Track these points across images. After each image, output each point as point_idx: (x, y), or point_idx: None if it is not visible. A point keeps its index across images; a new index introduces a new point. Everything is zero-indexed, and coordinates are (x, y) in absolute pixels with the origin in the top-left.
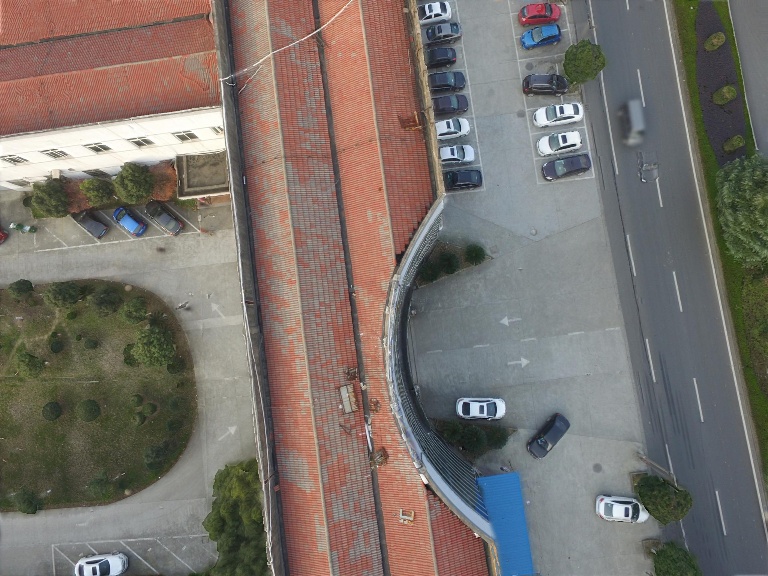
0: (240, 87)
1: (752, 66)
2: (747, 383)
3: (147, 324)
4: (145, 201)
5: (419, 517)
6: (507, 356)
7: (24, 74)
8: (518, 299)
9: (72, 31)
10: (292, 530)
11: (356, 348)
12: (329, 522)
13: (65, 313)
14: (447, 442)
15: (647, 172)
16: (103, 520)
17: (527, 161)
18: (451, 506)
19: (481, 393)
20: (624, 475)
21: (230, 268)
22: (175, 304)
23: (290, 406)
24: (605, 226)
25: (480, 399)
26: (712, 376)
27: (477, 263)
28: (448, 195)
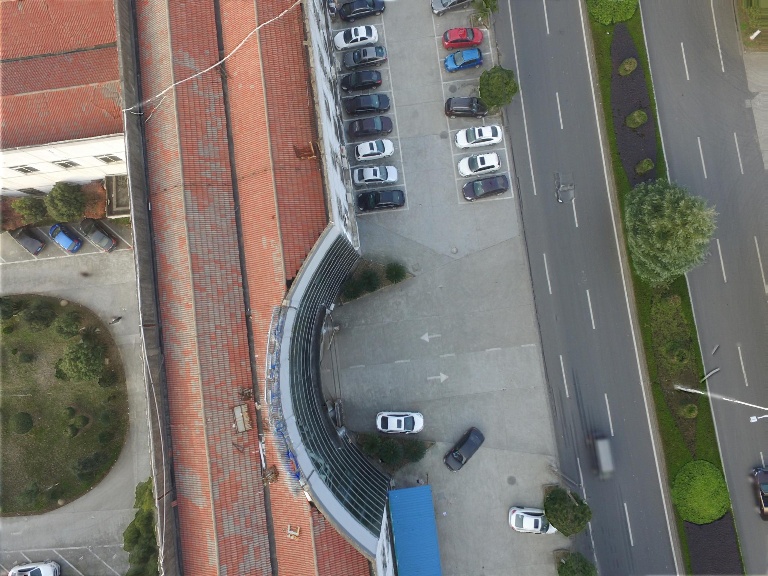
0: (146, 116)
1: (666, 90)
2: (655, 399)
3: (81, 338)
4: (81, 218)
5: (304, 532)
6: (427, 371)
7: None
8: (438, 316)
9: None
10: (187, 544)
11: (251, 369)
12: (219, 537)
13: (2, 327)
14: (366, 455)
15: (564, 193)
16: (37, 529)
17: (449, 181)
18: (332, 522)
19: (401, 407)
20: (537, 487)
21: None
22: (109, 319)
23: (186, 425)
24: (523, 245)
25: (399, 413)
26: (622, 392)
27: (397, 281)
28: (372, 214)
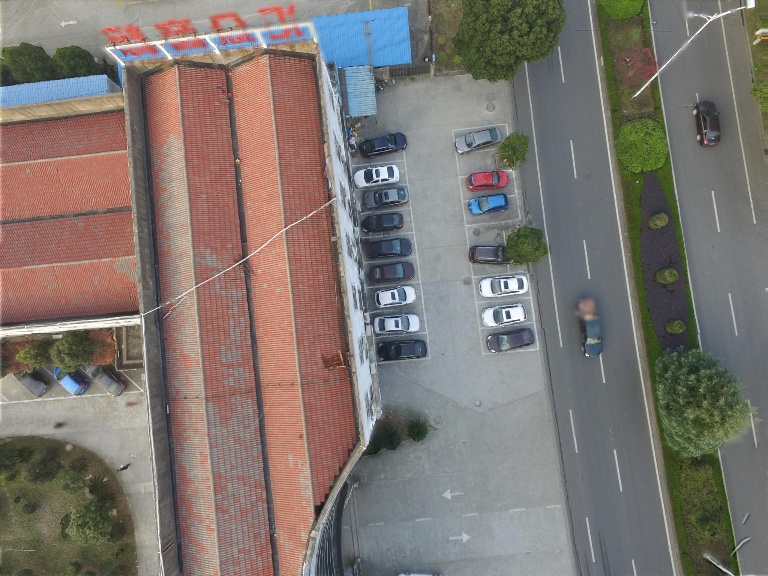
0: (165, 312)
1: (696, 242)
2: (683, 568)
3: None
4: None
5: None
6: (449, 531)
7: None
8: (461, 472)
9: (3, 217)
10: None
11: None
12: None
13: None
14: None
15: (591, 347)
16: None
17: (472, 330)
18: None
19: (422, 568)
20: None
21: None
22: (117, 466)
23: None
24: (548, 400)
25: None
26: (650, 558)
27: (419, 439)
28: (393, 363)
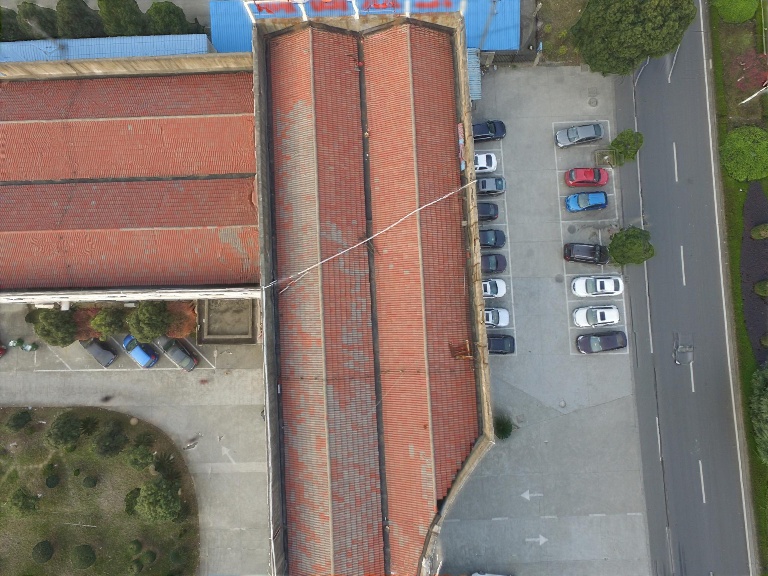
0: (281, 287)
1: None
2: None
3: None
4: None
5: None
6: (526, 532)
7: (42, 226)
8: (541, 473)
9: (97, 175)
10: None
11: None
12: None
13: None
14: None
15: (682, 354)
16: None
17: (562, 329)
18: None
19: (496, 568)
20: None
21: (244, 411)
22: (183, 443)
23: None
24: (635, 406)
25: None
26: (729, 572)
27: (504, 437)
28: None
